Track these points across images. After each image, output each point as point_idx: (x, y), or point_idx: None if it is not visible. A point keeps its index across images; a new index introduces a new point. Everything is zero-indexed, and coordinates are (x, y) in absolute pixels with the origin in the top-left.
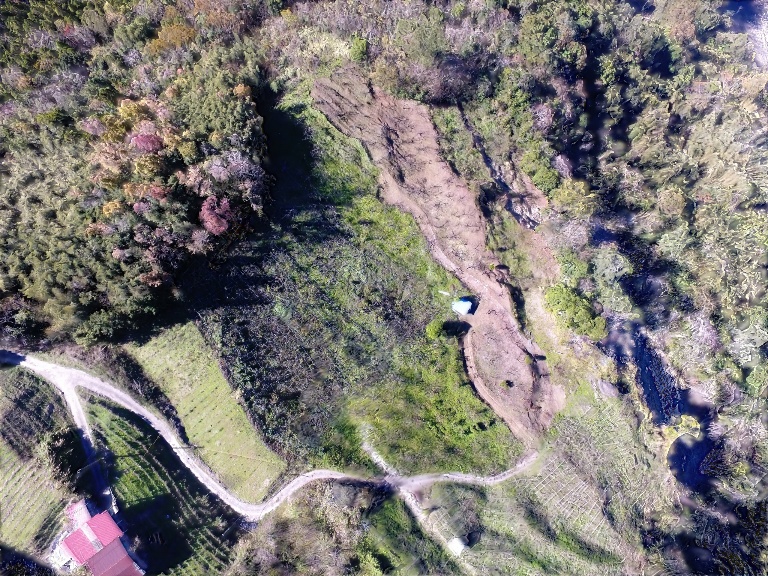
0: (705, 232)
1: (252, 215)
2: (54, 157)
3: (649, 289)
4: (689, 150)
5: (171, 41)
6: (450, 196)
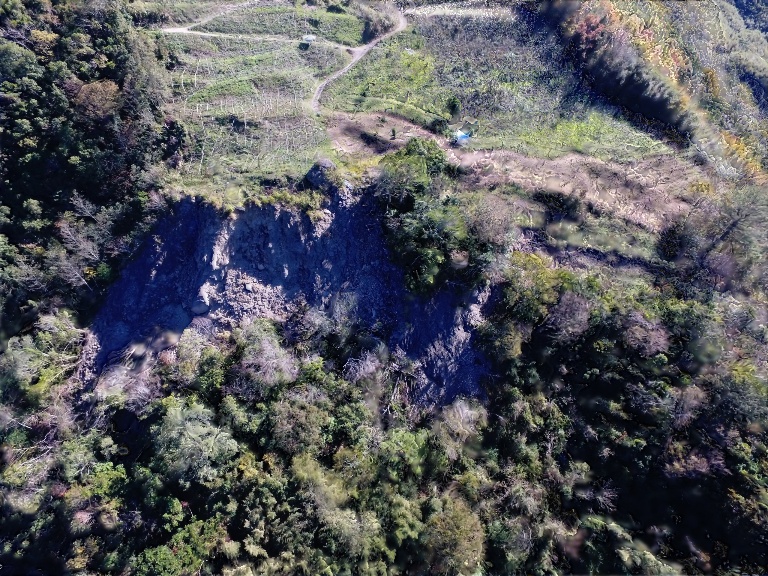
0: None
1: (597, 47)
2: None
3: None
4: None
5: None
6: None
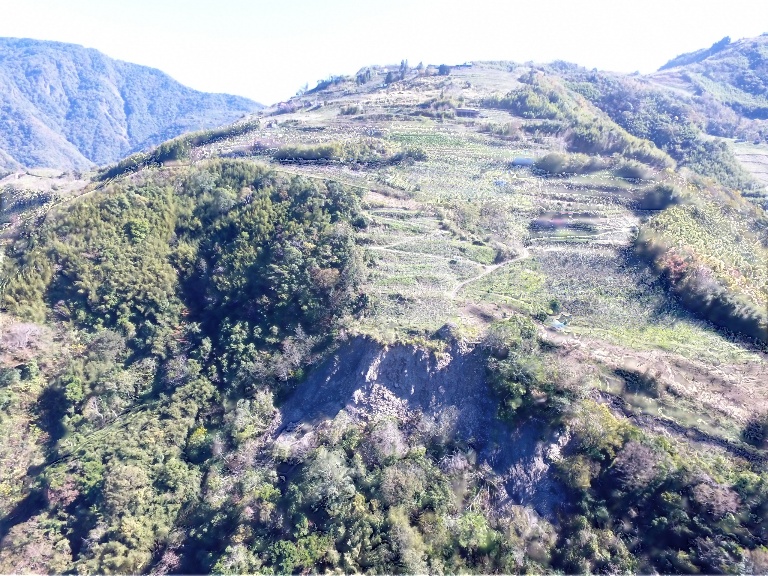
0: None
1: (683, 277)
2: None
3: None
4: None
5: None
6: None
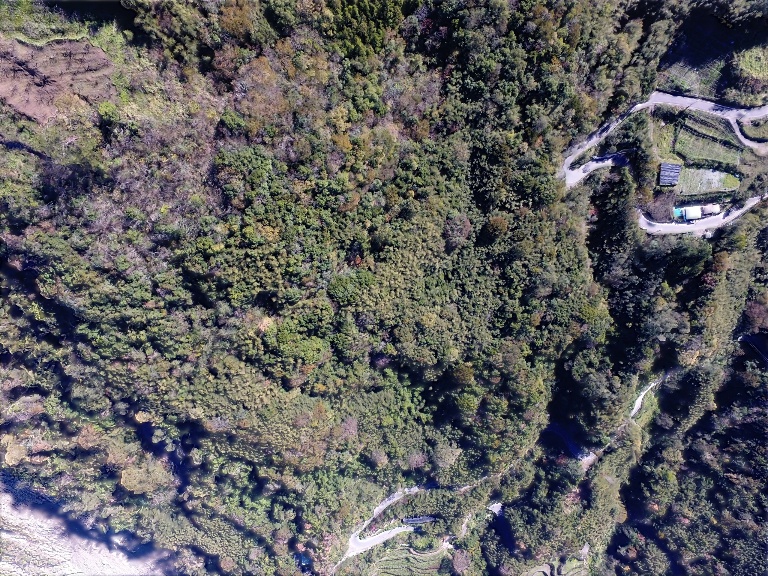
0: None
1: None
2: None
3: None
4: None
5: (230, 7)
6: None
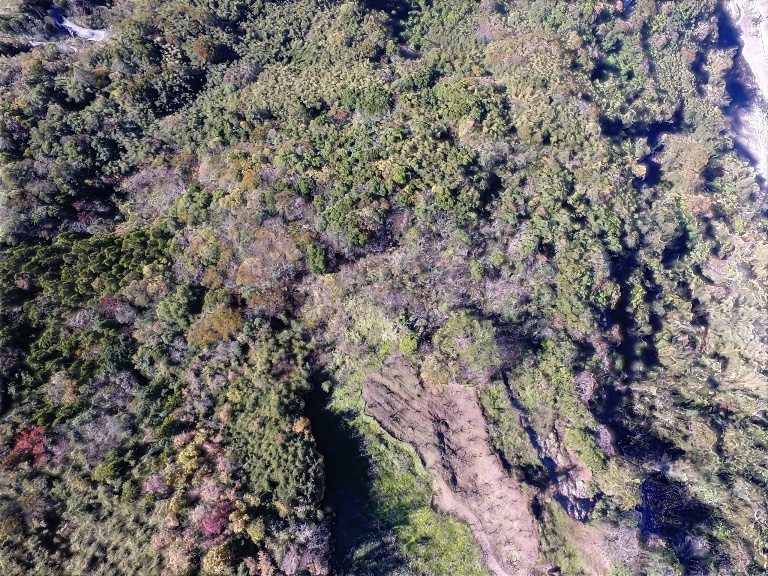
0: (734, 459)
1: None
2: (114, 521)
3: (688, 549)
4: (710, 342)
5: (218, 332)
6: (502, 497)
